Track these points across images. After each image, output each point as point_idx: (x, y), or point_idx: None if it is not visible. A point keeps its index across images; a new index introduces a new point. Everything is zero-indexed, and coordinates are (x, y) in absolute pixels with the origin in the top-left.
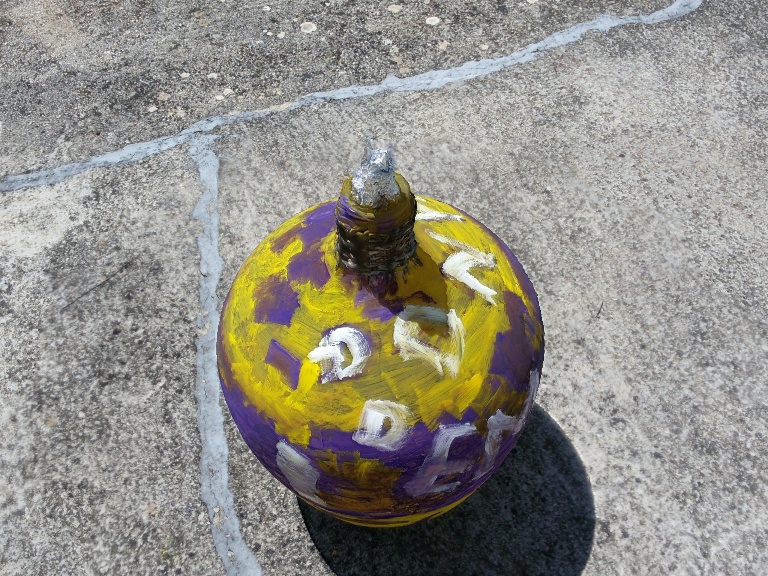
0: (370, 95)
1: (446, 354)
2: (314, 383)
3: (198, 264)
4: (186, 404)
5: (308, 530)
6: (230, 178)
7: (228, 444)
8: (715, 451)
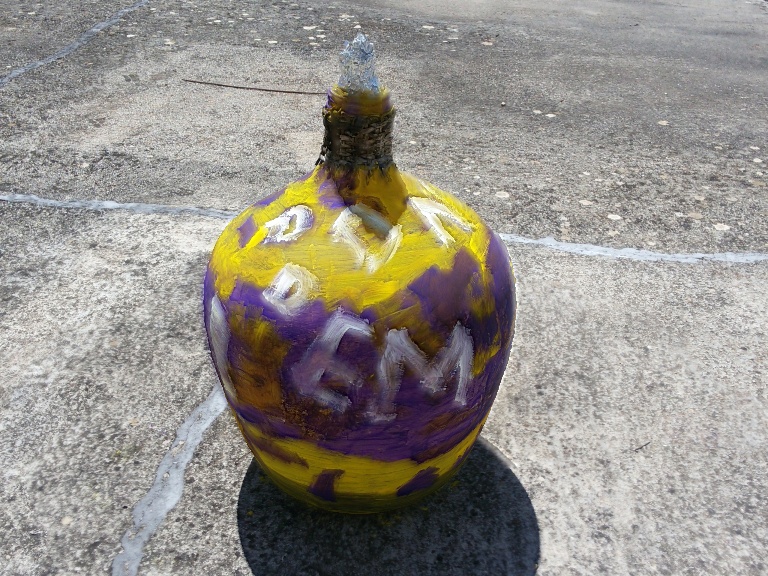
0: (524, 243)
1: (374, 251)
2: (259, 243)
3: None
4: None
5: (242, 488)
6: None
7: (227, 406)
8: None
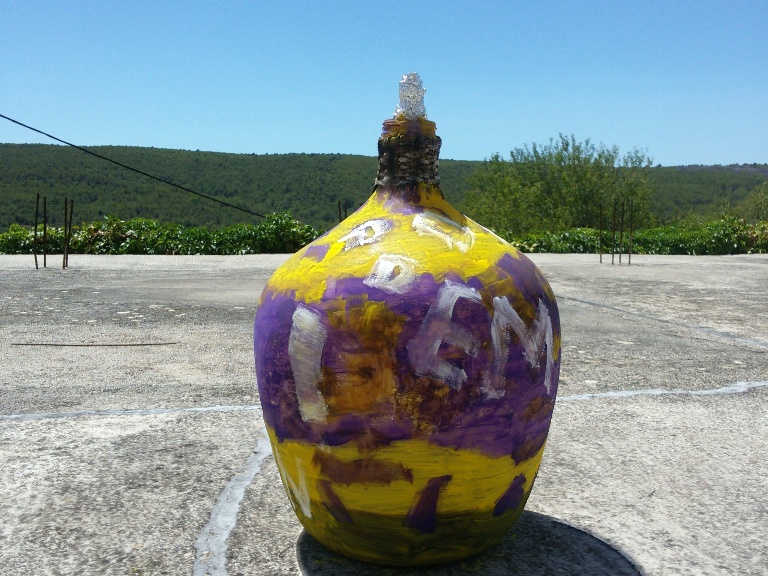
0: None
1: (457, 240)
2: (338, 253)
3: (252, 449)
4: (205, 502)
5: (301, 570)
6: None
7: (237, 522)
8: None
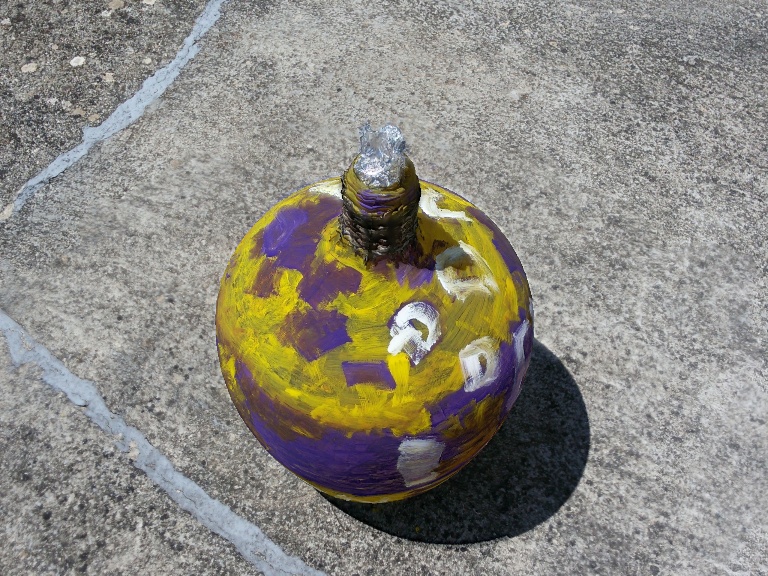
0: (84, 155)
1: (483, 277)
2: (409, 370)
3: (67, 400)
4: (181, 522)
5: (382, 531)
6: (20, 306)
7: (252, 523)
8: (583, 259)
